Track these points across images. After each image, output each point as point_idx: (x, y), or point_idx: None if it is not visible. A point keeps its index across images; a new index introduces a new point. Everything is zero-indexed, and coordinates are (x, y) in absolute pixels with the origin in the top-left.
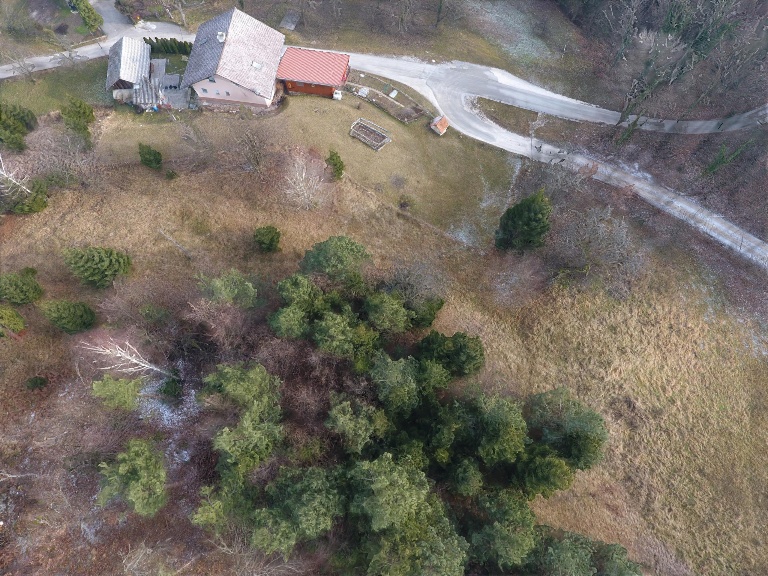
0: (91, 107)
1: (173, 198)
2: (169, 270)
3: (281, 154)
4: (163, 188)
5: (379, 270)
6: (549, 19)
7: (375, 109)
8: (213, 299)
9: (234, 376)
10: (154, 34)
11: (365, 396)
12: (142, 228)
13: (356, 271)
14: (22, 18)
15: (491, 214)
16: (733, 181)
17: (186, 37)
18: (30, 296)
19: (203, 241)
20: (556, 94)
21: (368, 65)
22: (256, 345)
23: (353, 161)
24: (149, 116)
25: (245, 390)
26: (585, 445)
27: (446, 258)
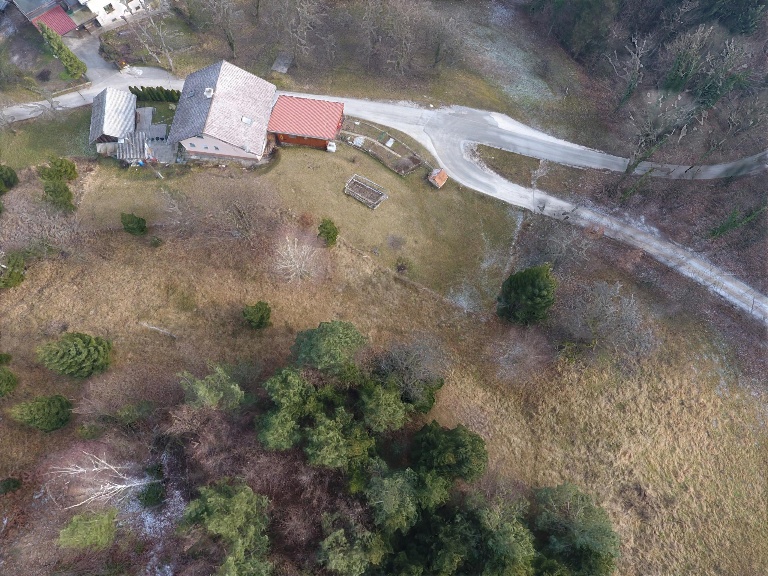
0: (73, 164)
1: (158, 269)
2: (153, 352)
3: (272, 218)
4: (147, 257)
5: (375, 355)
6: (550, 57)
7: (371, 160)
8: (197, 402)
9: (218, 504)
10: (140, 80)
11: (360, 518)
12: (124, 304)
13: (350, 362)
14: (3, 63)
15: (492, 275)
16: (743, 233)
17: (174, 83)
18: (3, 390)
19: (189, 318)
20: (558, 139)
21: (363, 111)
22: (243, 458)
23: (348, 222)
24: (134, 171)
25: (229, 525)
26: (596, 563)
27: (446, 327)
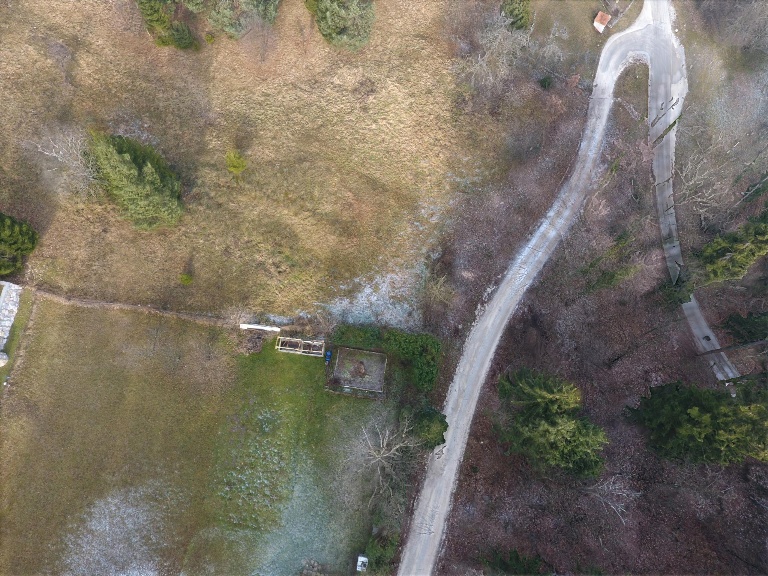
0: None
1: None
2: None
3: None
4: None
5: None
6: None
7: None
8: None
9: None
10: None
11: None
12: None
13: None
14: None
15: None
16: None
17: None
18: None
19: None
20: None
21: None
22: None
23: None
24: None
25: None
26: None
27: (475, 4)
